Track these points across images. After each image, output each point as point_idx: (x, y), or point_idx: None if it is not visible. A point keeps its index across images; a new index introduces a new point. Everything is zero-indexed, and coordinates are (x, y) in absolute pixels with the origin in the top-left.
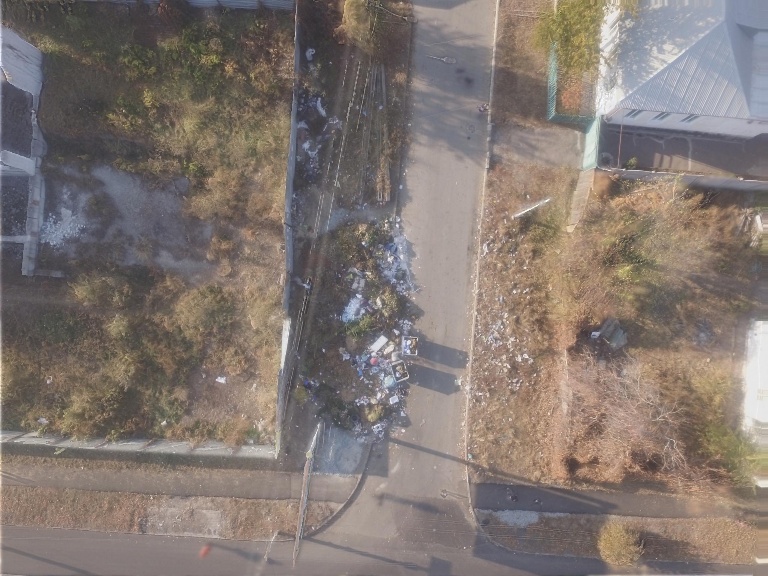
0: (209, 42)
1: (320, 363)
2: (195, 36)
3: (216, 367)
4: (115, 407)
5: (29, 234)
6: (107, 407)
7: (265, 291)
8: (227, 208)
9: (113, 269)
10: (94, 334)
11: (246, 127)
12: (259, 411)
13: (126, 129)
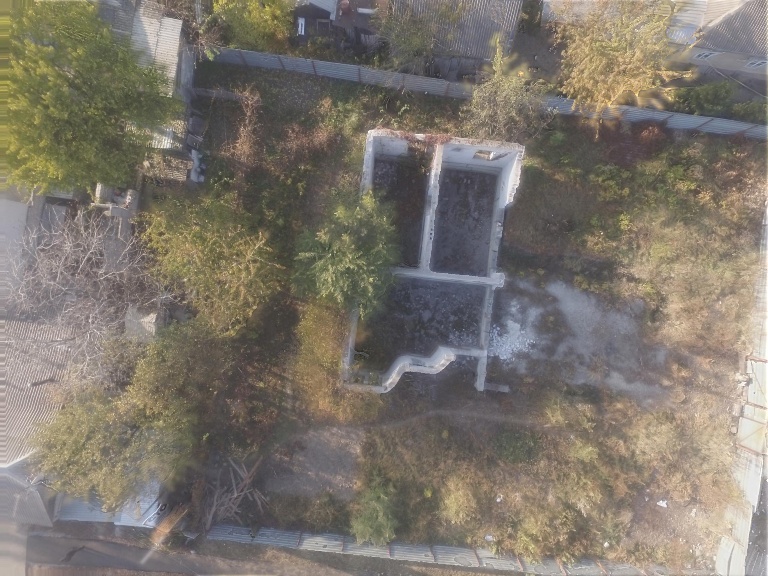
0: (689, 168)
1: (764, 493)
2: (672, 160)
3: (662, 492)
4: (569, 530)
5: (486, 349)
6: (562, 530)
7: (714, 419)
8: (696, 338)
9: (565, 388)
10: (549, 455)
11: (716, 256)
12: (698, 536)
13: (595, 249)
